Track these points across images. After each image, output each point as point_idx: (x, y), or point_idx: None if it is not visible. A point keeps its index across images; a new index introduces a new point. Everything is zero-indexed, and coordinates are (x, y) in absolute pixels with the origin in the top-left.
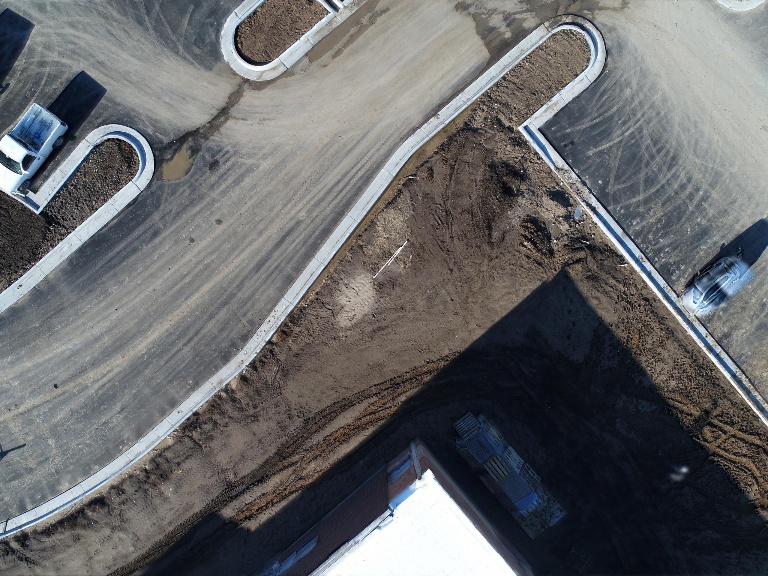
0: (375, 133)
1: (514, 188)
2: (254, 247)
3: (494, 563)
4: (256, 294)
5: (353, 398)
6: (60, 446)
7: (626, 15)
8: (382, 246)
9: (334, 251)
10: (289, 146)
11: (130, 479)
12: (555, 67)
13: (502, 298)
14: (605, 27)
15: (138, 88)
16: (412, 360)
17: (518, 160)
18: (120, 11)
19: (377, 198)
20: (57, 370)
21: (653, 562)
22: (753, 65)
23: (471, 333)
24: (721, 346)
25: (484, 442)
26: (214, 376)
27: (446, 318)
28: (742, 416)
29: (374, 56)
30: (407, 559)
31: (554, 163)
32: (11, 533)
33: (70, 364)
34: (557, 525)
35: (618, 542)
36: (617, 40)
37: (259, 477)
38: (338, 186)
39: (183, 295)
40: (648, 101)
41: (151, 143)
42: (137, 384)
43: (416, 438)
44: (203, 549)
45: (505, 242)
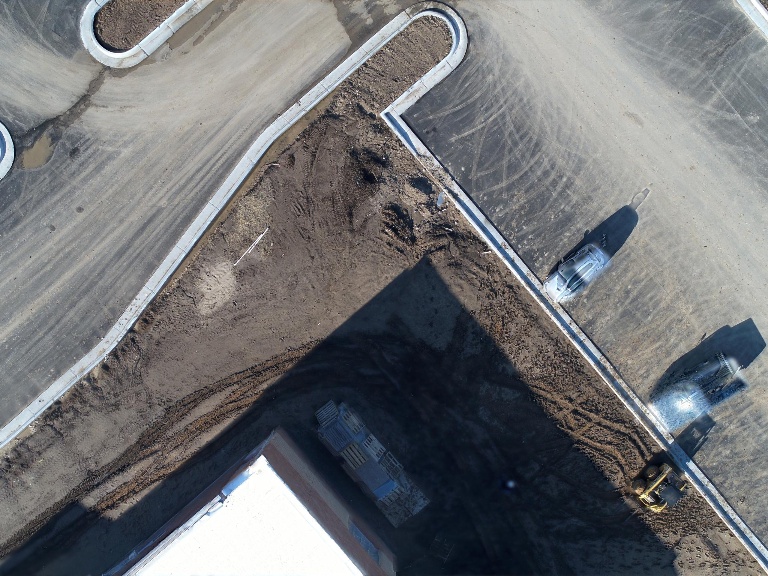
0: (236, 120)
1: (374, 175)
2: (115, 235)
3: (329, 550)
4: (117, 282)
5: (214, 386)
6: None
7: (488, 1)
8: (243, 234)
9: (195, 239)
10: (150, 133)
11: None
12: (417, 54)
13: (364, 285)
14: (467, 13)
15: None
16: (273, 348)
17: (380, 147)
18: None
19: (238, 185)
20: None
21: (518, 551)
22: (615, 51)
23: (333, 321)
24: (585, 333)
25: (341, 430)
26: (75, 365)
27: (308, 306)
28: (607, 404)
29: (235, 43)
30: (243, 546)
31: (416, 150)
32: None
33: None
34: (420, 514)
35: (482, 531)
36: (479, 26)
37: (120, 466)
38: (199, 173)
39: (44, 283)
40: (511, 88)
41: (11, 131)
42: None
43: (278, 426)
44: (64, 539)
45: (367, 229)
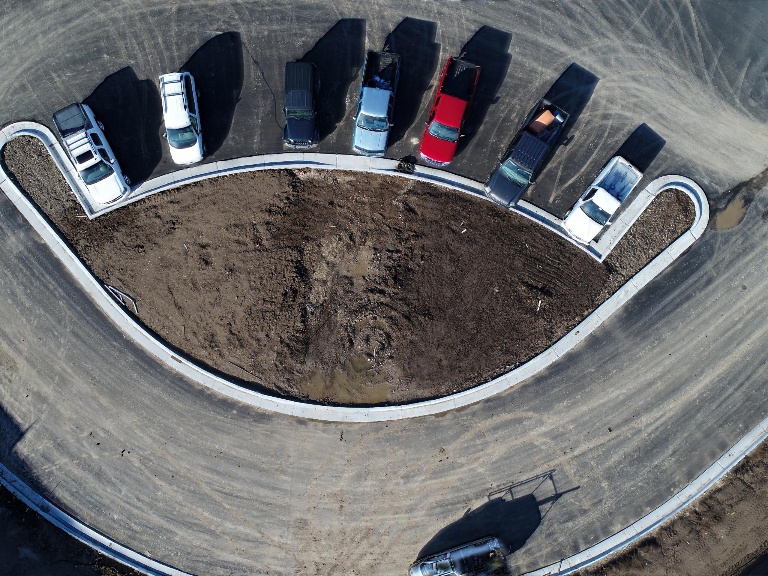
0: None
1: None
2: None
3: None
4: None
5: None
6: (613, 488)
7: None
8: None
9: None
10: None
11: (681, 521)
12: None
13: None
14: None
15: (696, 139)
16: None
17: None
18: (681, 65)
19: None
20: (611, 414)
21: None
22: None
23: None
24: None
25: None
26: (764, 420)
27: None
28: None
29: None
30: None
31: None
32: (567, 573)
33: (624, 408)
34: None
35: None
36: None
37: None
38: None
39: (735, 341)
40: None
41: (707, 193)
42: (689, 428)
43: None
44: None
45: None
